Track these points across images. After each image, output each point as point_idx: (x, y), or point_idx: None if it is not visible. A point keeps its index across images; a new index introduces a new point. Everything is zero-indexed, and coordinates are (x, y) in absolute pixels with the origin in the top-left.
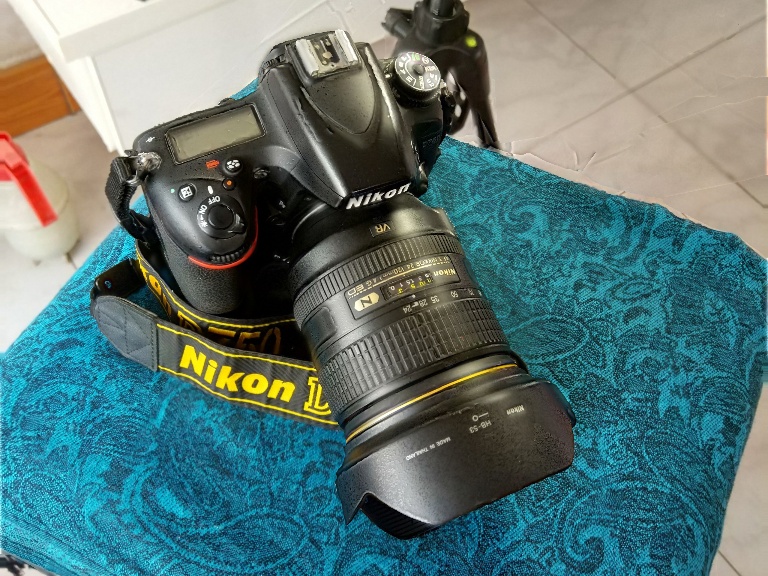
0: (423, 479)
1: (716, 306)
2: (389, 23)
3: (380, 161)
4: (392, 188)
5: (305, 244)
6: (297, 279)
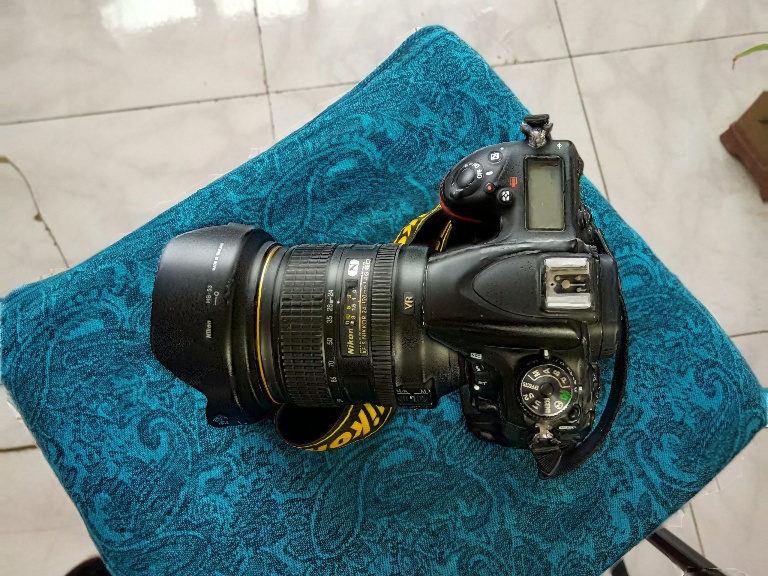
0: (202, 246)
1: None
2: None
3: (444, 295)
4: None
5: None
6: None
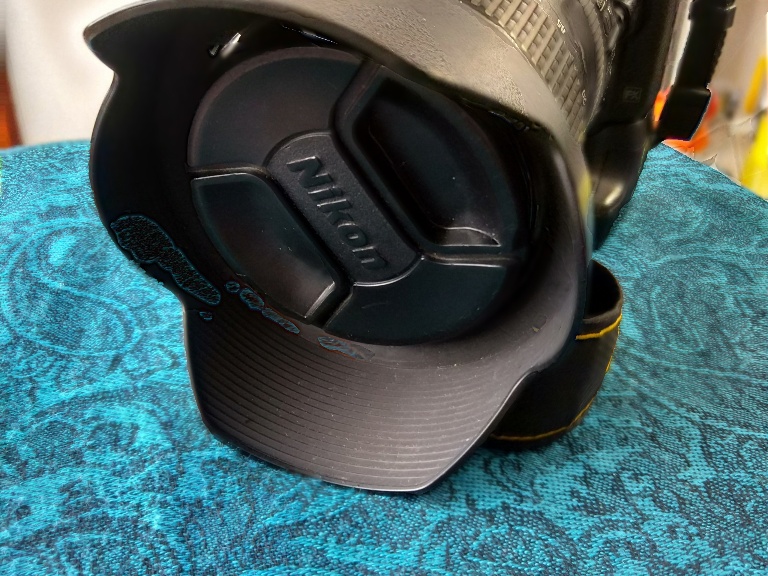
0: None
1: None
2: None
3: None
4: None
5: None
6: None
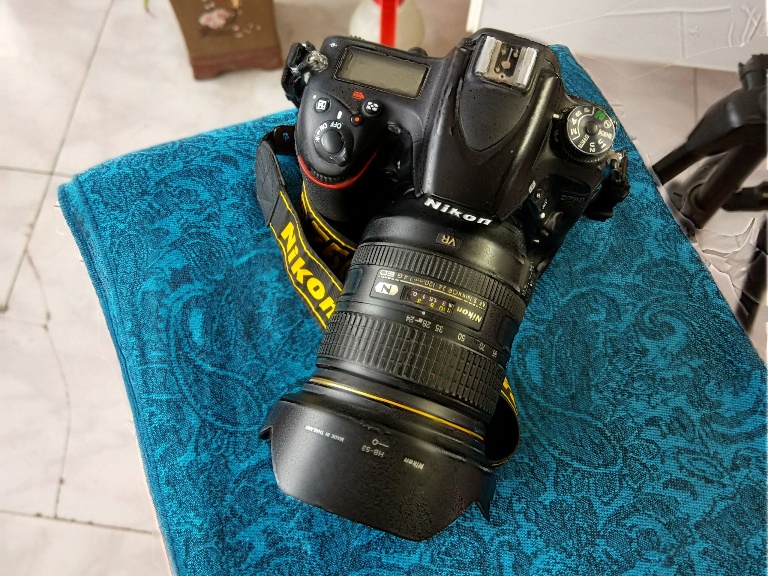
0: (302, 451)
1: (767, 544)
2: (746, 67)
3: (474, 184)
4: (472, 214)
5: (393, 209)
6: (369, 232)
